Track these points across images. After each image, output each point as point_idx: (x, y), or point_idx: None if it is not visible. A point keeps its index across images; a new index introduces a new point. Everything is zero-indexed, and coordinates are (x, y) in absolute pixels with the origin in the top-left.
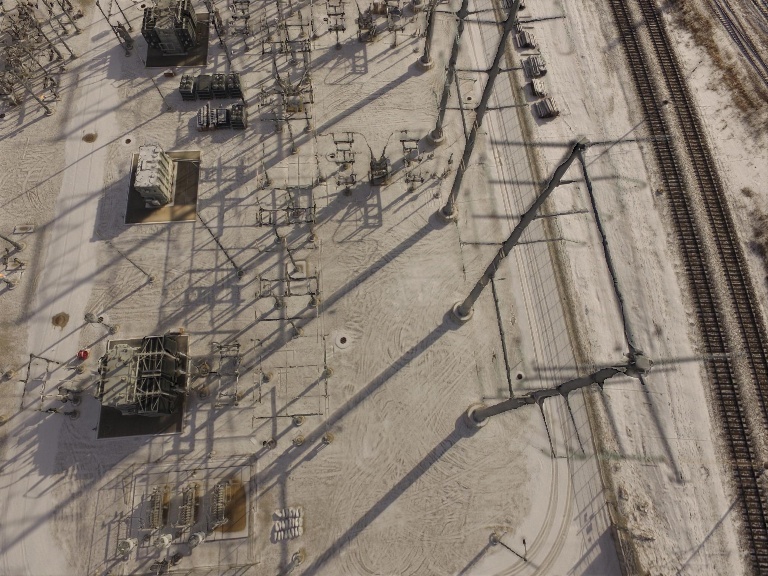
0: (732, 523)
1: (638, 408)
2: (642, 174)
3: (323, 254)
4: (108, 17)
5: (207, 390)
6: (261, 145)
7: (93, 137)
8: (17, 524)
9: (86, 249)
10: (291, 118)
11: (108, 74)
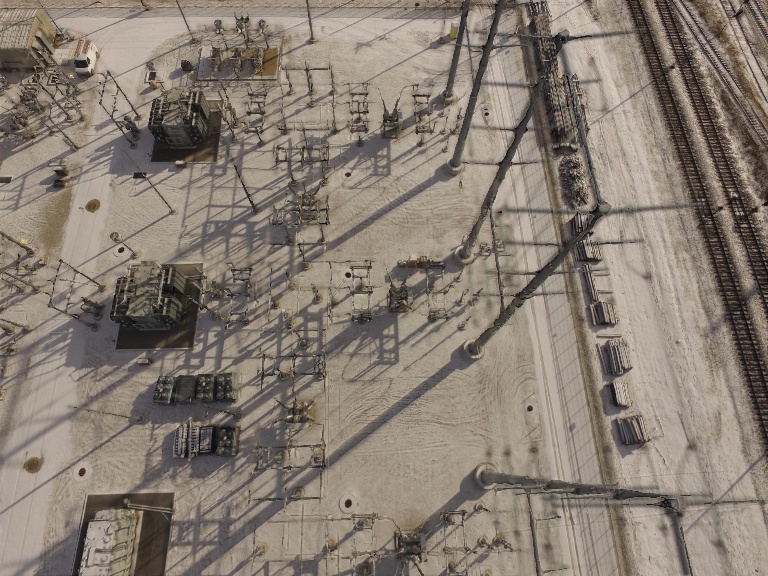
0: None
1: None
2: (765, 549)
3: None
4: (66, 307)
5: None
6: (255, 483)
7: (38, 463)
8: None
9: None
10: (294, 498)
11: (67, 358)
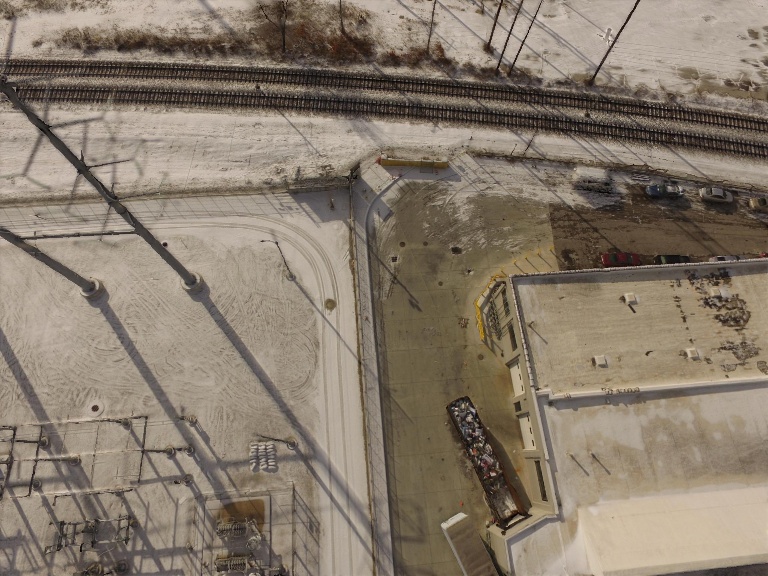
0: (293, 117)
1: (206, 160)
2: None
3: None
4: None
5: (119, 563)
6: None
7: None
8: None
9: None
10: None
11: None
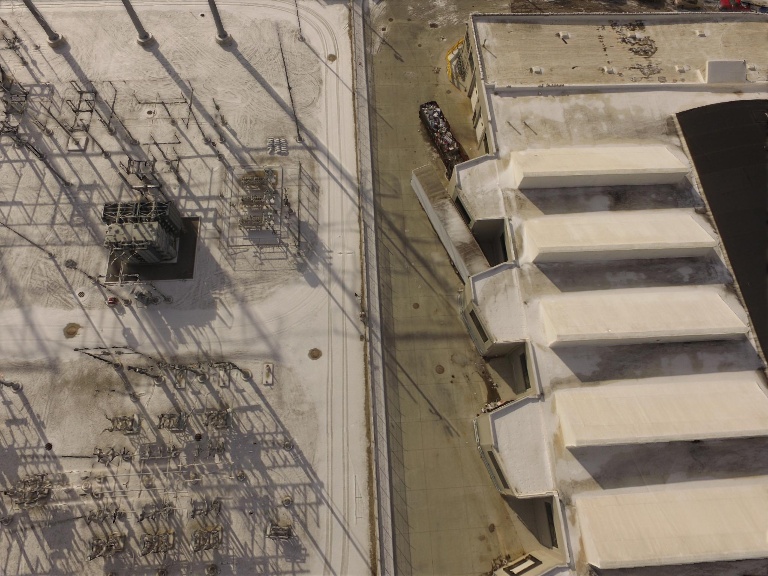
0: None
1: None
2: None
3: None
4: None
5: None
6: None
7: None
8: (252, 329)
9: None
10: None
11: None
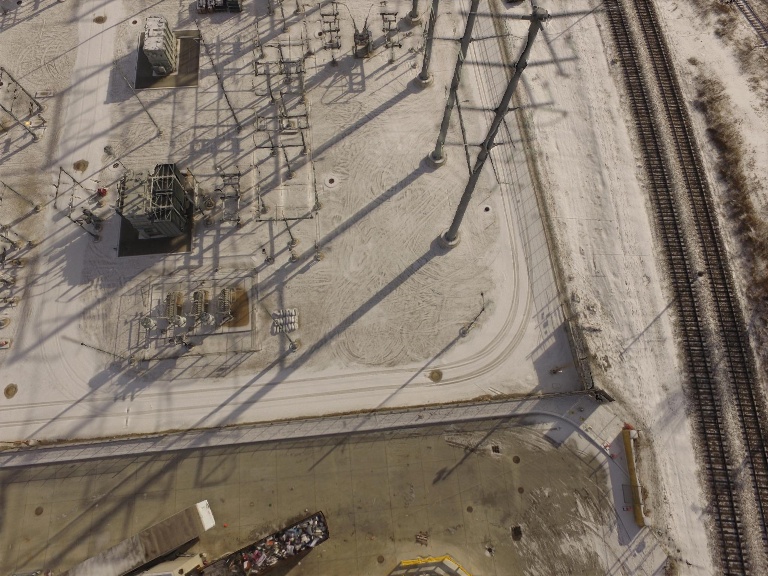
0: (668, 317)
1: (590, 233)
2: (599, 47)
3: (313, 113)
4: None
5: (212, 219)
6: None
7: (103, 19)
8: (51, 322)
9: (101, 110)
10: None
11: None
